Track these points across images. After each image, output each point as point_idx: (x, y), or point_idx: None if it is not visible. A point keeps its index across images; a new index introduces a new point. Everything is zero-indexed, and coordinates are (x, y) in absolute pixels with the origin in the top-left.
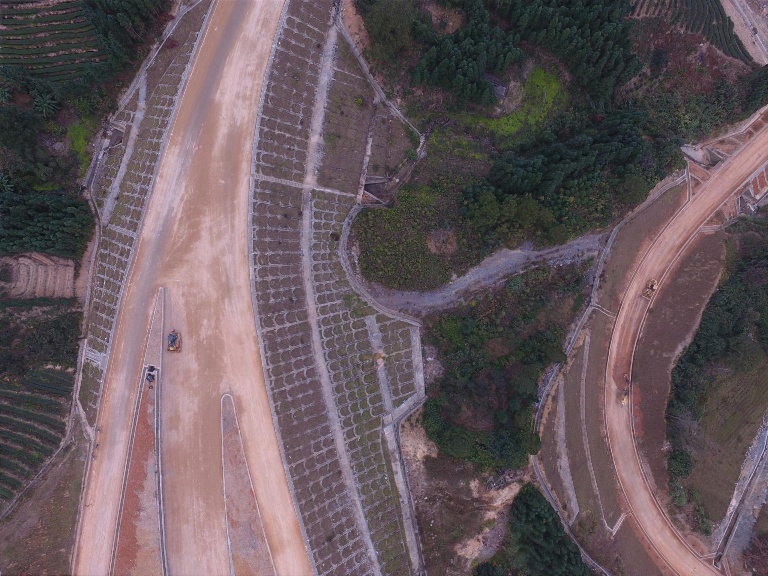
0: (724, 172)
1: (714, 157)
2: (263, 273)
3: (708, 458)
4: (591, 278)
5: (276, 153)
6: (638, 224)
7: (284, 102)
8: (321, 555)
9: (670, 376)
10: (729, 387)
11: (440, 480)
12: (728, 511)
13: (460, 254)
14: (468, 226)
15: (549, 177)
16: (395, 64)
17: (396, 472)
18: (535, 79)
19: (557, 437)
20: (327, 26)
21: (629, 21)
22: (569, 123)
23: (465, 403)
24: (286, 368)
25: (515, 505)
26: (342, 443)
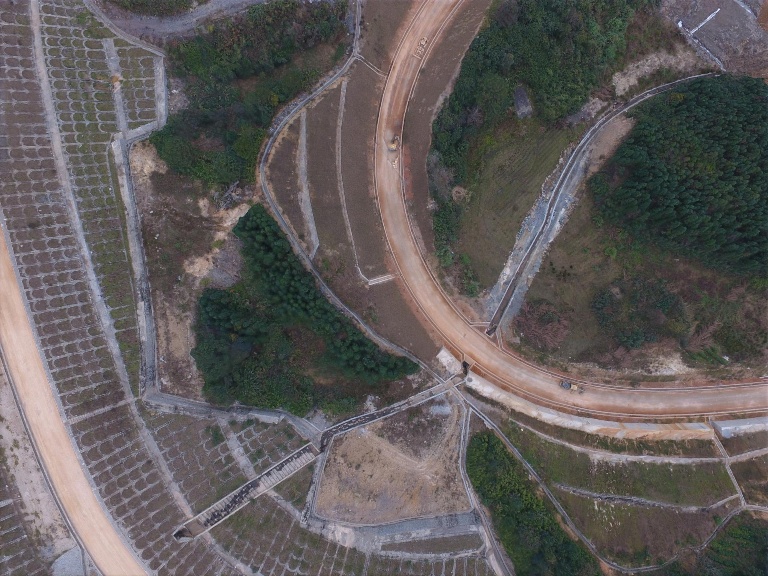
0: None
1: None
2: None
3: (482, 225)
4: (351, 25)
5: None
6: None
7: None
8: (19, 236)
9: (431, 128)
10: (506, 155)
11: (167, 195)
12: (502, 280)
13: None
14: None
15: None
16: None
17: (122, 185)
18: None
19: (298, 170)
20: None
21: None
22: None
23: (207, 134)
24: None
25: None
26: (59, 145)
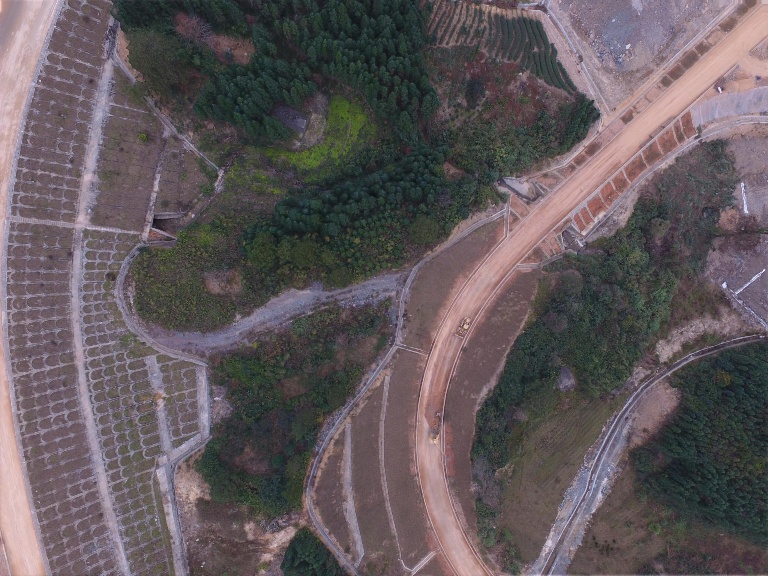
0: (544, 208)
1: (538, 191)
2: (19, 317)
3: (524, 498)
4: (394, 317)
5: (39, 194)
6: (444, 262)
7: (48, 141)
8: None
9: (475, 418)
10: (548, 427)
11: (212, 522)
12: (543, 552)
13: (243, 295)
14: (253, 266)
15: (327, 219)
16: (175, 99)
17: (168, 513)
18: (339, 111)
19: (343, 480)
20: (102, 60)
21: (437, 50)
22: (374, 157)
23: (250, 444)
24: (42, 412)
25: (287, 549)
26: (105, 486)
